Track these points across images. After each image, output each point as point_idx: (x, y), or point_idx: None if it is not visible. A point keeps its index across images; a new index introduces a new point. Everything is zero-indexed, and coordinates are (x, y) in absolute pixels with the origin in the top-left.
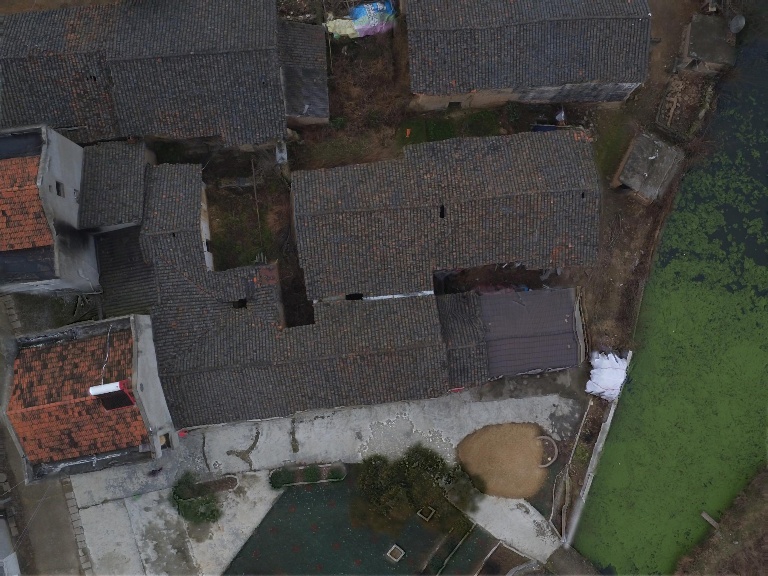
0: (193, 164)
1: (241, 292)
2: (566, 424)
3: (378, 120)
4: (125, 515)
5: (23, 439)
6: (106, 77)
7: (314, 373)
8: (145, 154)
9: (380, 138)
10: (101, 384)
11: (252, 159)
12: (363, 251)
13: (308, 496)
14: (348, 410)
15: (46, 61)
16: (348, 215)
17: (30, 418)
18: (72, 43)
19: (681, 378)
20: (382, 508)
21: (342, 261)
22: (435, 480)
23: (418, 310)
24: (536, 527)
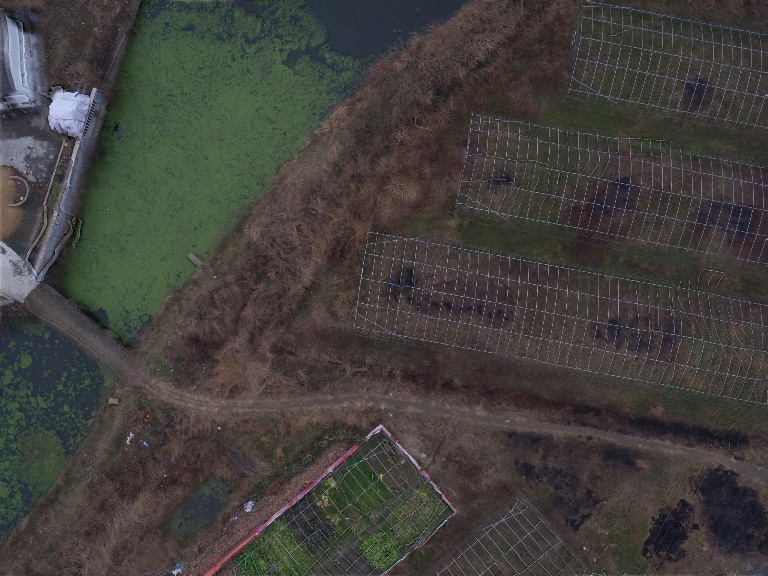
0: None
1: None
2: (41, 166)
3: None
4: None
5: None
6: None
7: None
8: None
9: None
10: None
11: None
12: None
13: None
14: None
15: None
16: None
17: None
18: None
19: (172, 125)
20: None
21: None
22: None
23: None
24: (13, 267)
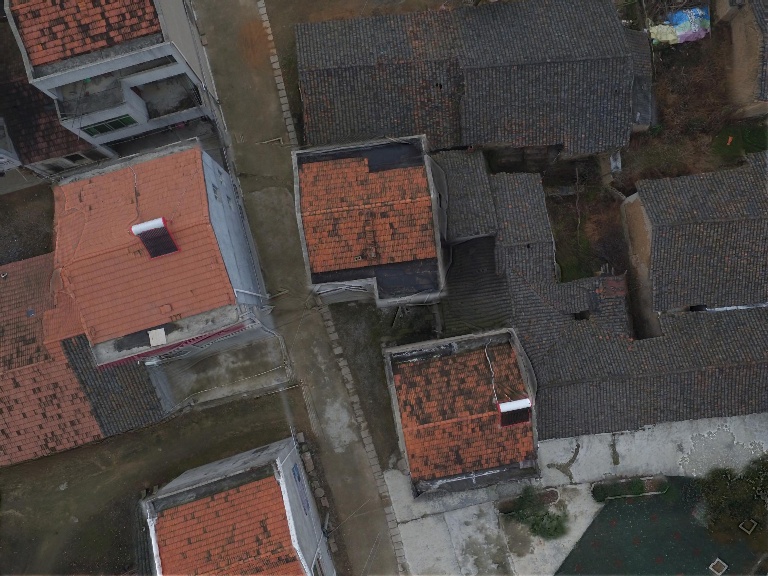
0: (531, 173)
1: (582, 303)
2: None
3: (695, 127)
4: (445, 529)
5: (412, 456)
6: (453, 85)
7: (670, 386)
8: (483, 163)
9: (697, 146)
10: (510, 401)
11: (577, 167)
12: (714, 262)
13: (629, 509)
14: (670, 422)
15: (395, 69)
16: (706, 225)
17: (424, 435)
18: (419, 50)
19: None
20: (704, 521)
21: (692, 272)
22: (757, 492)
23: (767, 321)
24: None
